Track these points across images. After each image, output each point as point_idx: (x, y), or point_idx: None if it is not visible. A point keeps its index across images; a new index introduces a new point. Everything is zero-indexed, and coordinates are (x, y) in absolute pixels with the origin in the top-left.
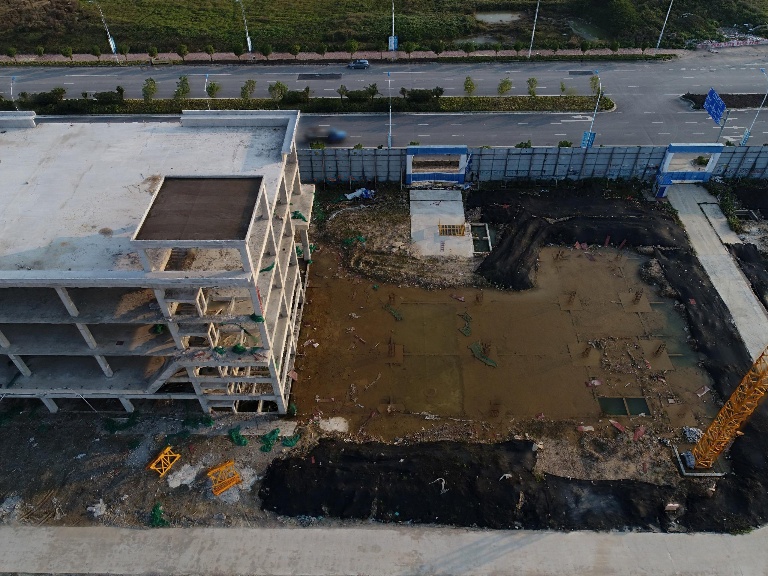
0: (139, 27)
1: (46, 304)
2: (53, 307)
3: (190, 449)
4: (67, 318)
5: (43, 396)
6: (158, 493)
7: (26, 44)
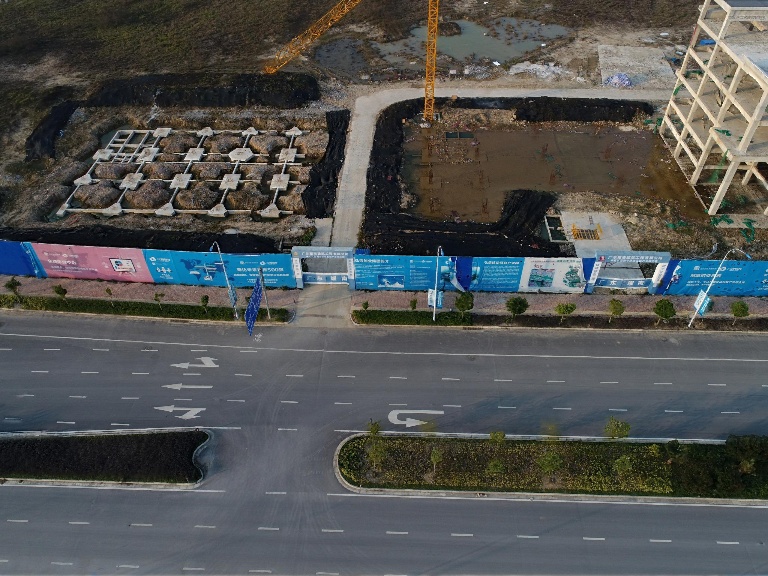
0: None
1: None
2: None
3: None
4: None
5: None
6: None
7: None
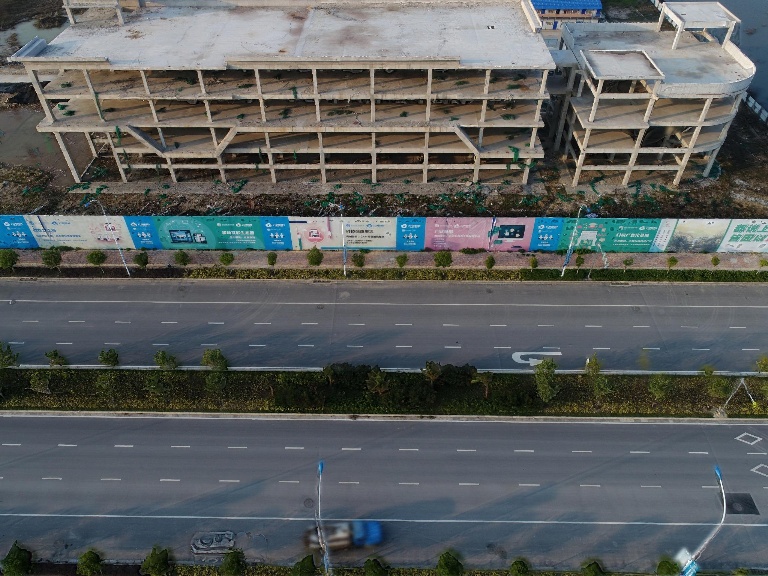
0: None
1: None
2: None
3: None
4: None
5: None
6: None
7: None
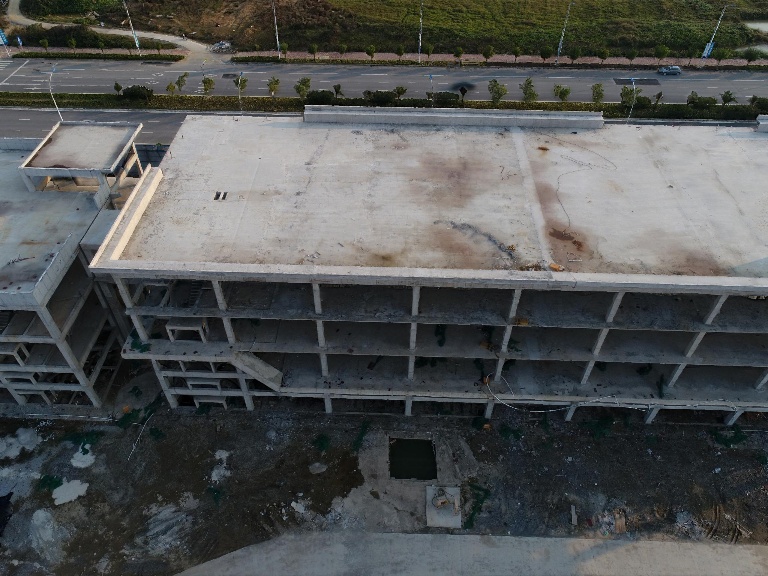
0: (411, 27)
1: (761, 313)
2: None
3: None
4: None
5: (660, 407)
6: None
7: (308, 41)
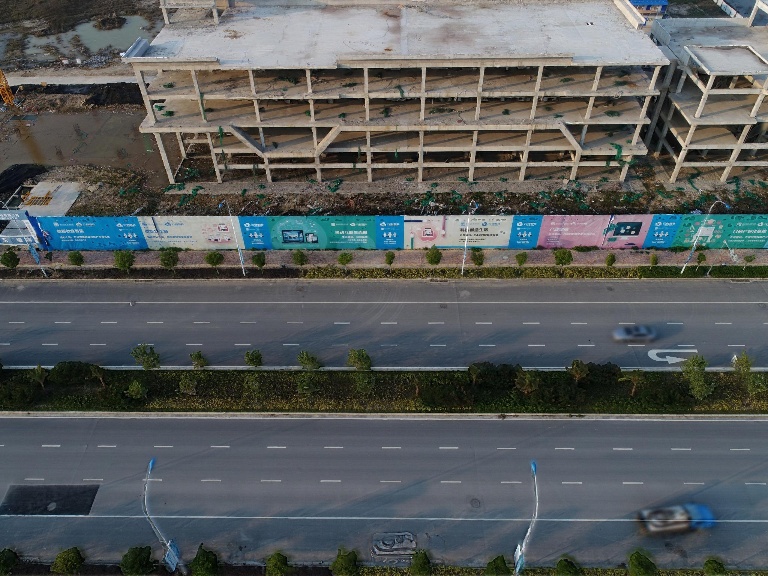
0: None
1: None
2: None
3: None
4: None
5: None
6: None
7: None
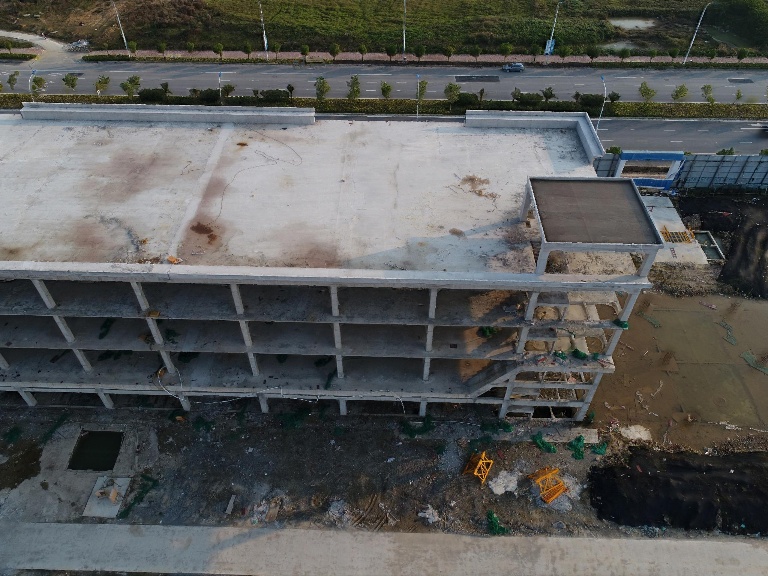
0: (275, 25)
1: (395, 305)
2: (404, 308)
3: (500, 455)
4: (425, 320)
5: (344, 398)
6: (485, 500)
7: (166, 40)
